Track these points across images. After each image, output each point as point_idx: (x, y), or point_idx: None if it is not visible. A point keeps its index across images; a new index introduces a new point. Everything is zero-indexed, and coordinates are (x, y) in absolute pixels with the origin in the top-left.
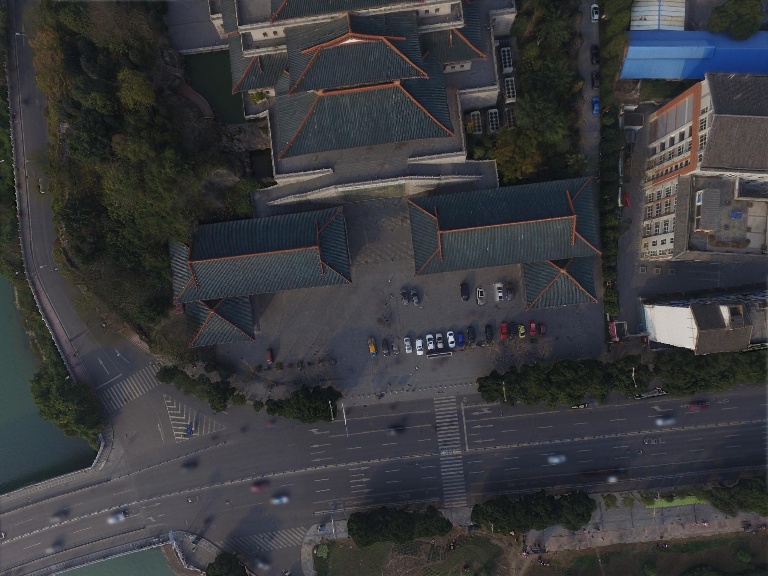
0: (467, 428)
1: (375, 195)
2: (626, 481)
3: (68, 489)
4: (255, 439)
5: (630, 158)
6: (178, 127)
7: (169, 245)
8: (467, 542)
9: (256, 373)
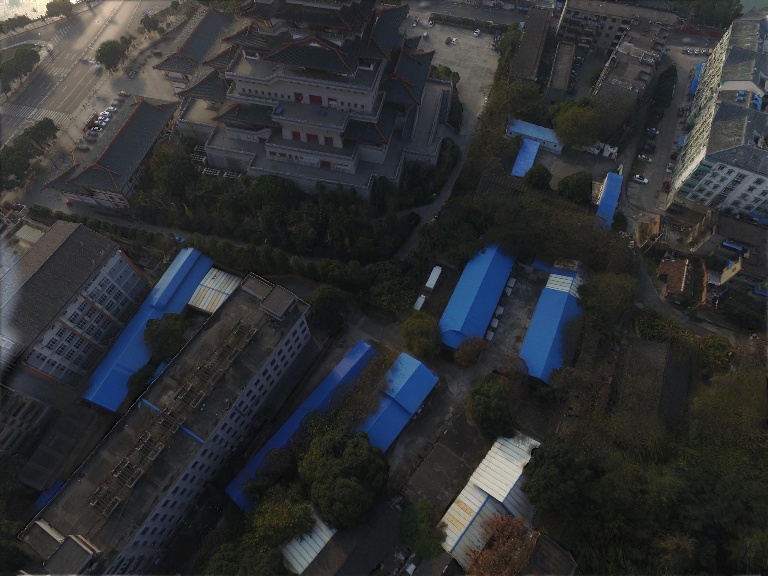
0: None
1: None
2: None
3: None
4: None
5: None
6: None
7: None
8: None
9: None
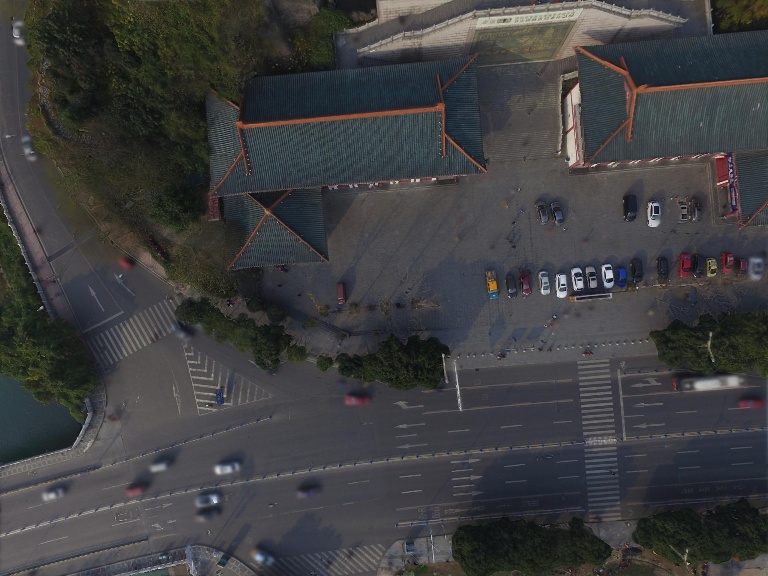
0: (625, 406)
1: (516, 51)
2: None
3: (36, 479)
4: (315, 413)
5: None
6: None
7: (206, 106)
8: (620, 573)
9: (320, 317)
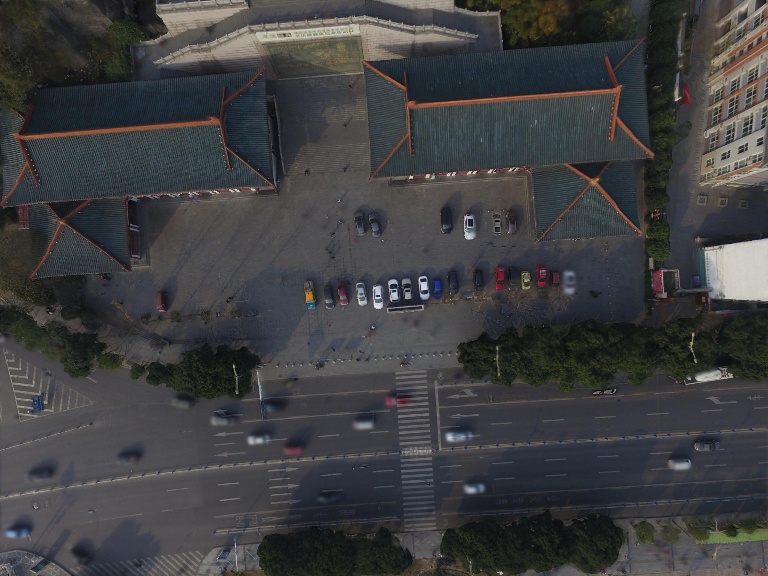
0: (441, 417)
1: (319, 64)
2: (666, 503)
3: None
4: (135, 421)
5: (690, 39)
6: None
7: None
8: None
9: (141, 325)
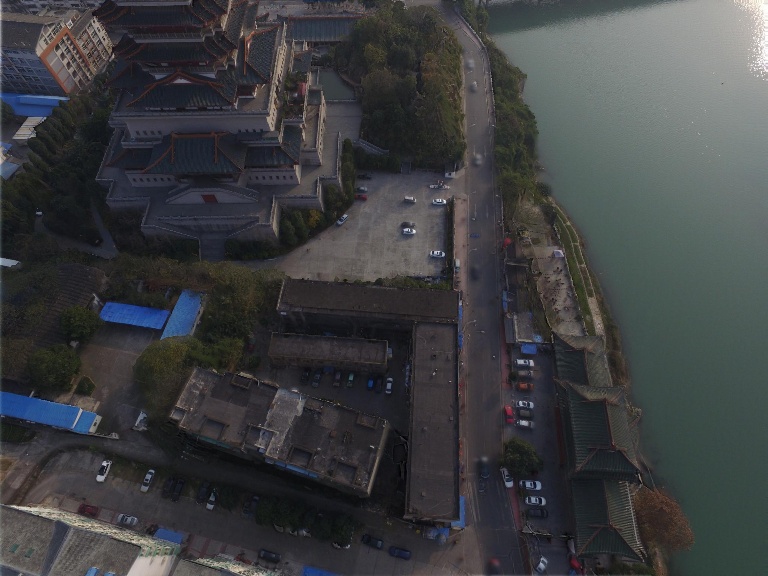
0: None
1: None
2: None
3: None
4: None
5: None
6: (357, 54)
7: None
8: None
9: None
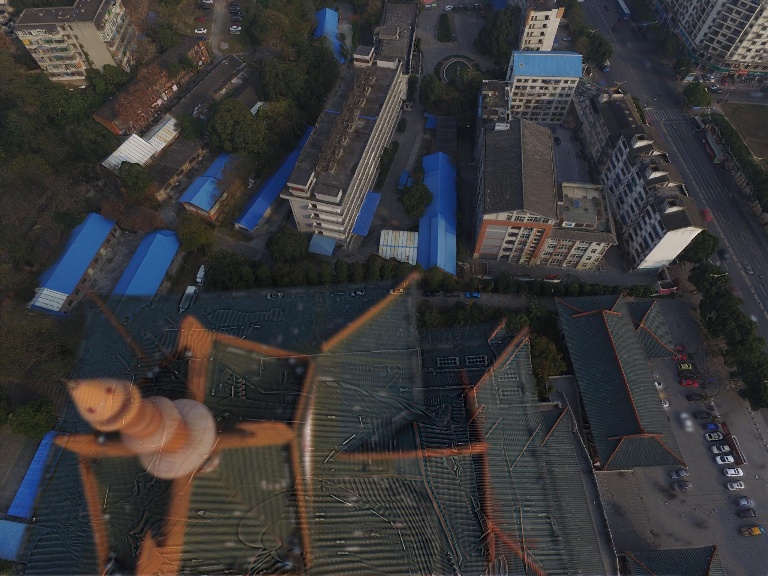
0: None
1: None
2: None
3: None
4: None
5: None
6: None
7: None
8: None
9: None
